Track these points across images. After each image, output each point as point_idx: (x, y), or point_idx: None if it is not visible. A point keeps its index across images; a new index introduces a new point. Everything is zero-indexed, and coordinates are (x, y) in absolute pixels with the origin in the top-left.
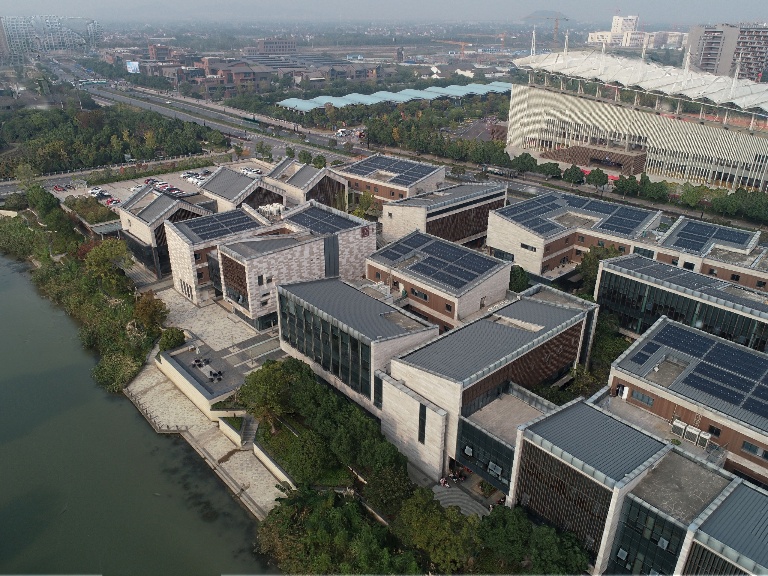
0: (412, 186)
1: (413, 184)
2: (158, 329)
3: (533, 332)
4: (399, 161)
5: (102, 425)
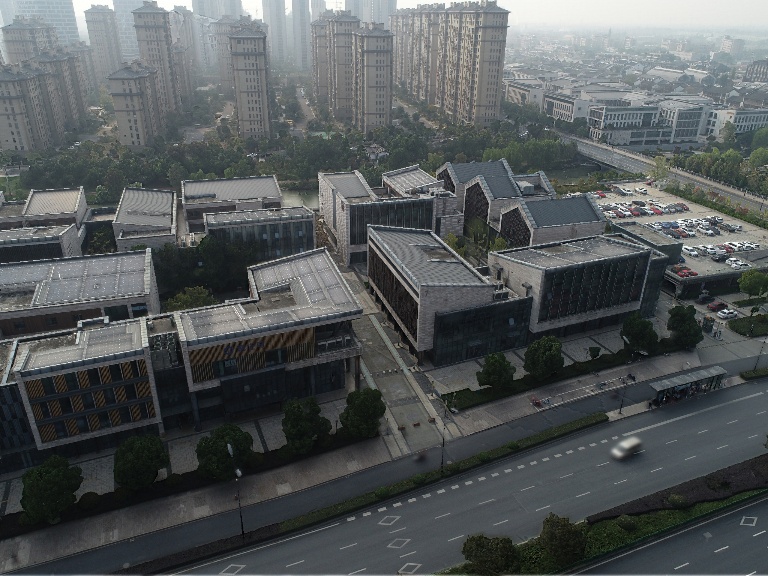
0: (493, 254)
1: (495, 253)
2: None
3: (128, 210)
4: (606, 257)
5: None
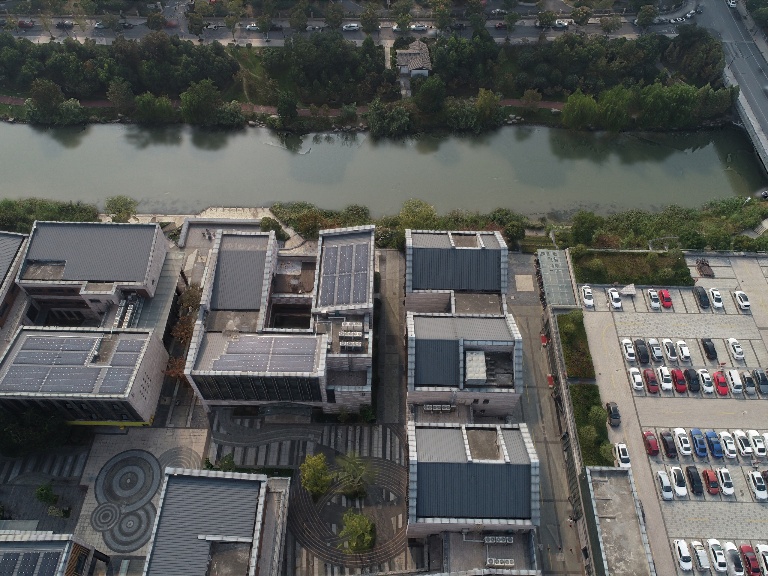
0: None
1: None
2: (313, 238)
3: None
4: None
5: (249, 194)
